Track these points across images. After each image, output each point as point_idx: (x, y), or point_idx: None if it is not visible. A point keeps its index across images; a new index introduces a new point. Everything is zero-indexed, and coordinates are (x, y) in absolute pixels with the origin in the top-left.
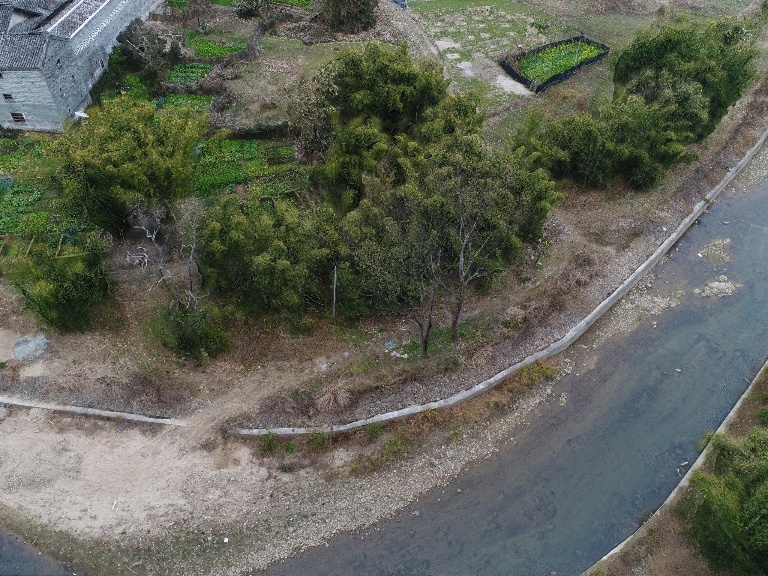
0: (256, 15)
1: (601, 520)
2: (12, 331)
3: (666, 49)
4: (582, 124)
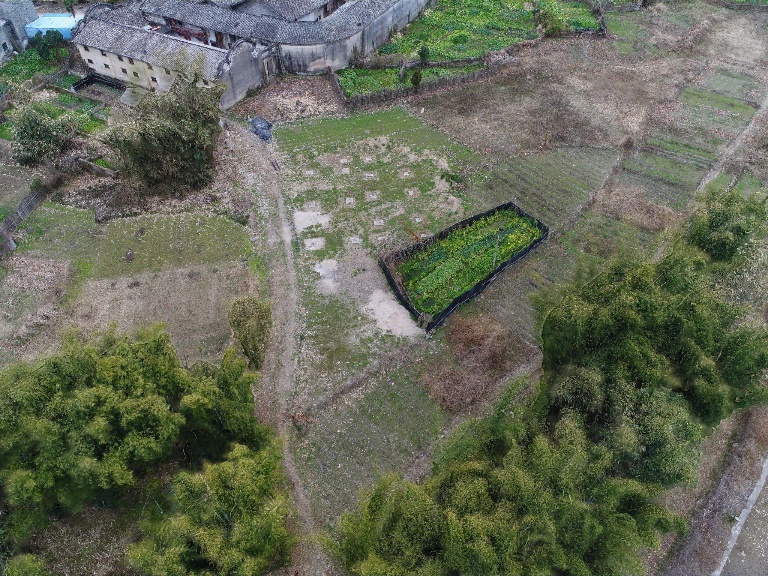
0: (42, 163)
1: None
2: None
3: (624, 327)
4: (461, 530)
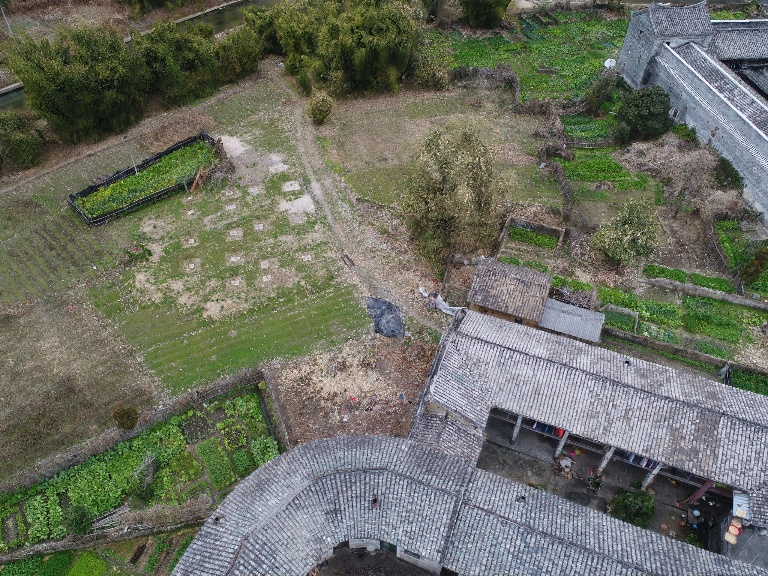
0: None
1: (260, 1)
2: (514, 8)
3: None
4: None
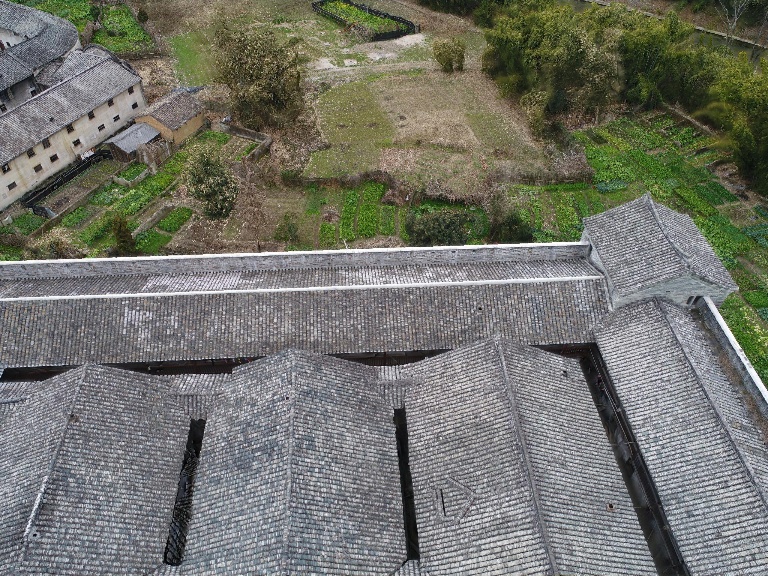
0: None
1: None
2: None
3: None
4: None
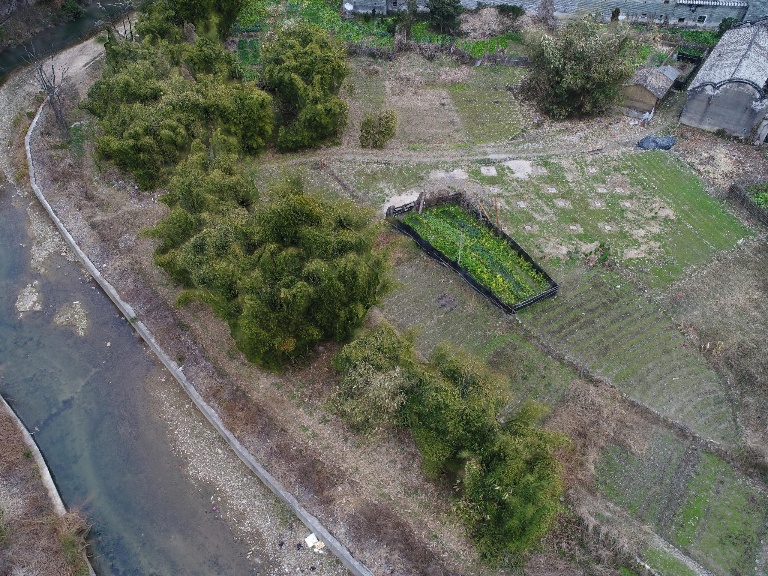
0: None
1: None
2: None
3: None
4: None
